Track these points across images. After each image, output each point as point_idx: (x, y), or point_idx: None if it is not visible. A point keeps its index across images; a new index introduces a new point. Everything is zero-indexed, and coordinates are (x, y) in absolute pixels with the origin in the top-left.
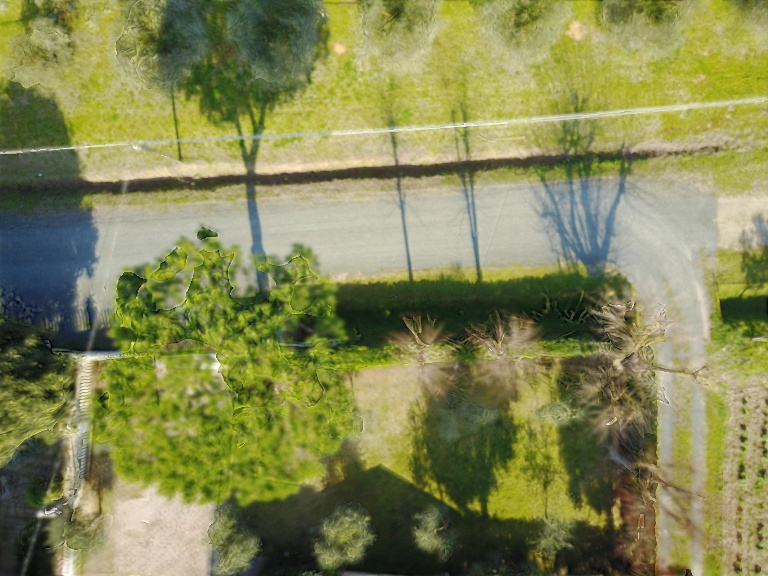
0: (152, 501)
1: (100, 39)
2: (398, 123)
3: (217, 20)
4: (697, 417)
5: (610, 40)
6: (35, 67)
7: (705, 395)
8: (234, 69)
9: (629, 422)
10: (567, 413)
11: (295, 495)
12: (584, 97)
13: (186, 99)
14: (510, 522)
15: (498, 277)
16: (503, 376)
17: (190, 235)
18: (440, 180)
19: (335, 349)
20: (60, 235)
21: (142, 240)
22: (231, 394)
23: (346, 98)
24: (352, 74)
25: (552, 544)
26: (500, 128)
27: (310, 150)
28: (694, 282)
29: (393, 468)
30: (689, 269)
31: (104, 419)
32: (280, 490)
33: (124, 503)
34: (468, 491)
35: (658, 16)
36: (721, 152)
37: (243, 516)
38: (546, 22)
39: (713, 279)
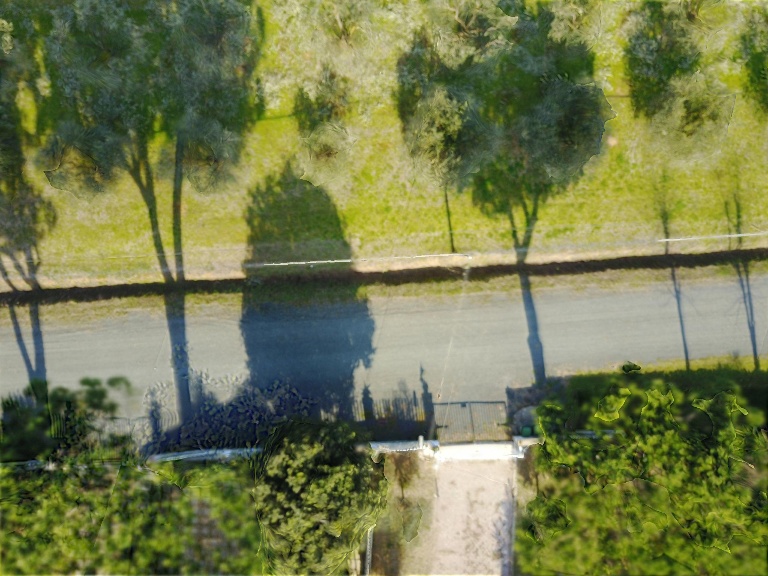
0: None
1: (373, 133)
2: (671, 214)
3: (490, 114)
4: None
5: None
6: (321, 164)
7: None
8: (506, 161)
9: None
10: None
11: None
12: None
13: (459, 191)
14: None
15: None
16: None
17: (465, 326)
18: (714, 270)
19: None
20: (336, 327)
21: (417, 331)
22: (510, 484)
23: (619, 190)
24: (625, 166)
25: None
26: None
27: (582, 241)
28: None
29: (677, 558)
30: None
31: (384, 511)
32: None
33: None
34: None
35: None
36: None
37: None
38: None
39: None
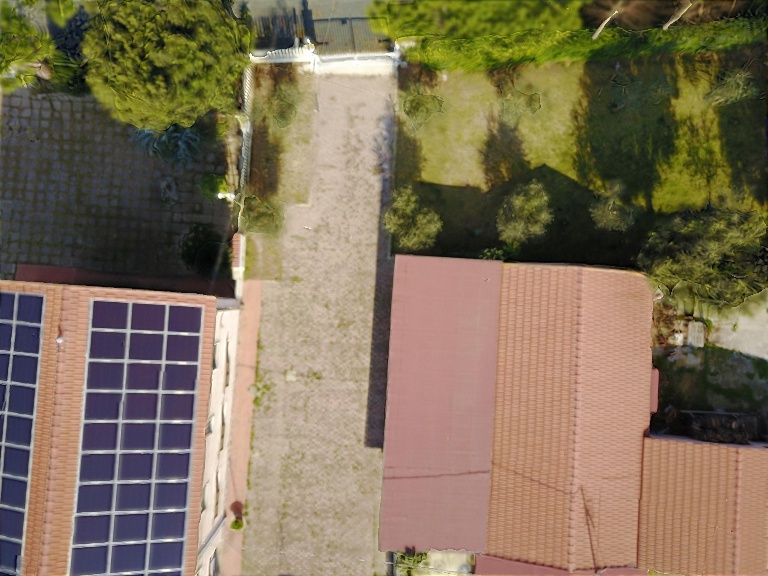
0: (314, 207)
1: None
2: None
3: None
4: None
5: None
6: None
7: None
8: None
9: None
10: (738, 91)
11: (459, 198)
12: None
13: None
14: (675, 216)
15: None
16: (664, 74)
17: None
18: None
19: None
20: None
21: None
22: (391, 100)
23: None
24: None
25: None
26: None
27: None
28: None
29: (557, 168)
30: None
31: (263, 125)
32: (444, 193)
33: None
34: (632, 189)
35: None
36: None
37: None
38: None
39: None
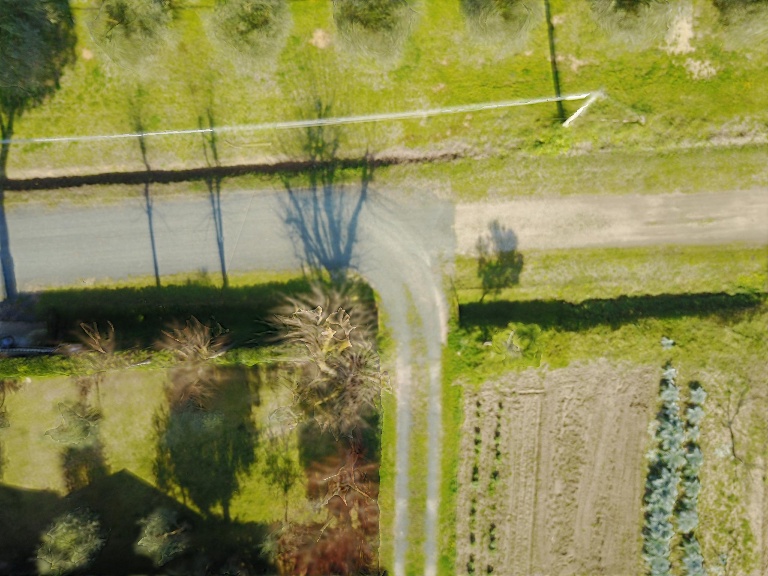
0: None
1: None
2: (146, 129)
3: None
4: (433, 420)
5: (350, 48)
6: None
7: (441, 398)
8: None
9: (327, 426)
10: (294, 417)
11: (40, 500)
12: (327, 104)
13: None
14: (251, 525)
15: (244, 282)
16: (246, 380)
17: None
18: (187, 186)
19: (67, 354)
20: None
21: None
22: None
23: (94, 104)
24: (100, 80)
25: (278, 547)
26: (246, 134)
27: (60, 155)
28: (433, 287)
29: (137, 472)
30: (428, 274)
31: None
32: (25, 495)
33: None
34: (211, 495)
35: (373, 26)
36: (458, 159)
37: None
38: (283, 30)
39: (451, 284)
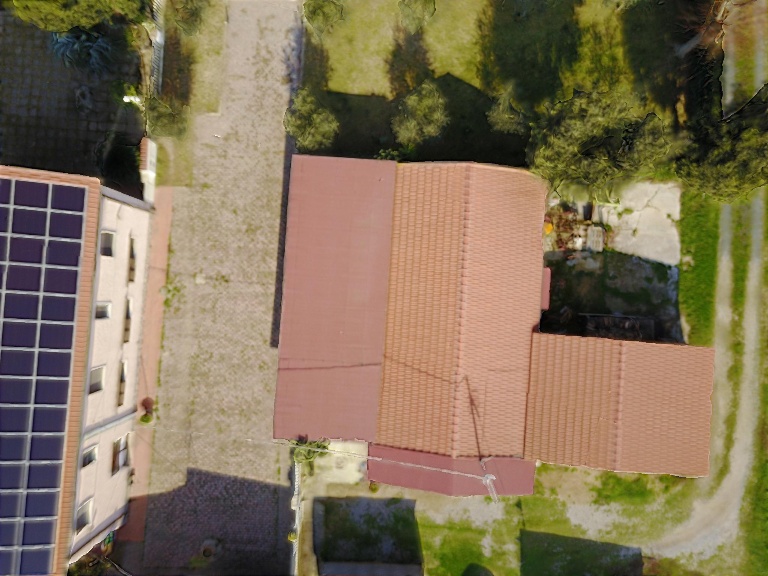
0: (224, 116)
1: None
2: None
3: None
4: (758, 14)
5: None
6: None
7: None
8: None
9: None
10: None
11: (364, 107)
12: None
13: None
14: None
15: None
16: None
17: None
18: None
19: None
20: None
21: None
22: (299, 11)
23: None
24: None
25: None
26: None
27: None
28: None
29: (461, 76)
30: None
31: (175, 36)
32: (350, 102)
33: (196, 118)
34: (534, 96)
35: None
36: None
37: (319, 102)
38: None
39: None
